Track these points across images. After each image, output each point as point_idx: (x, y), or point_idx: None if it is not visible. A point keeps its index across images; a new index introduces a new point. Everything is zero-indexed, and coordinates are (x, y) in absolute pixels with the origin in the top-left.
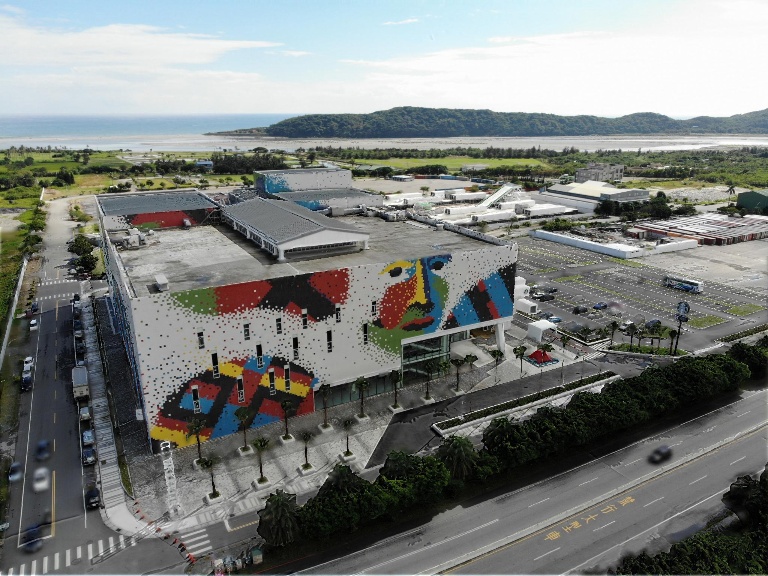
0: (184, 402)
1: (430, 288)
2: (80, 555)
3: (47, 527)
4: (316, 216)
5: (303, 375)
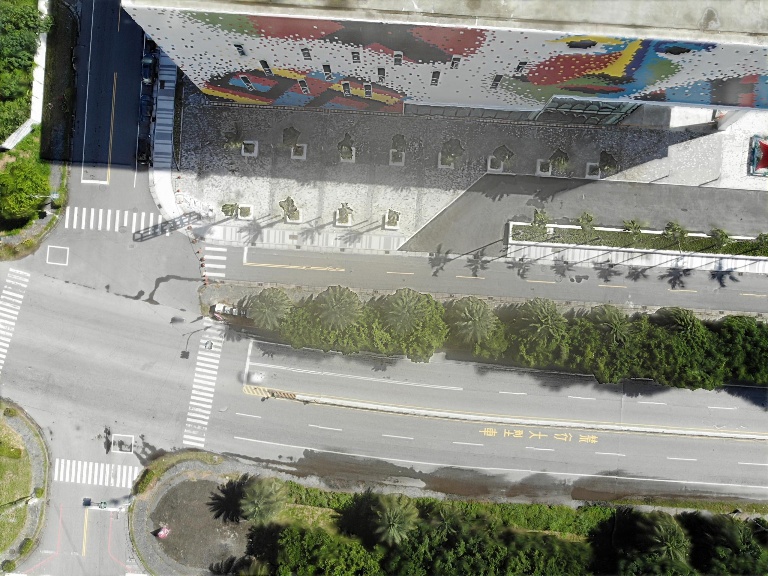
0: (233, 82)
1: (640, 66)
2: (126, 223)
3: (104, 168)
4: None
5: (391, 92)
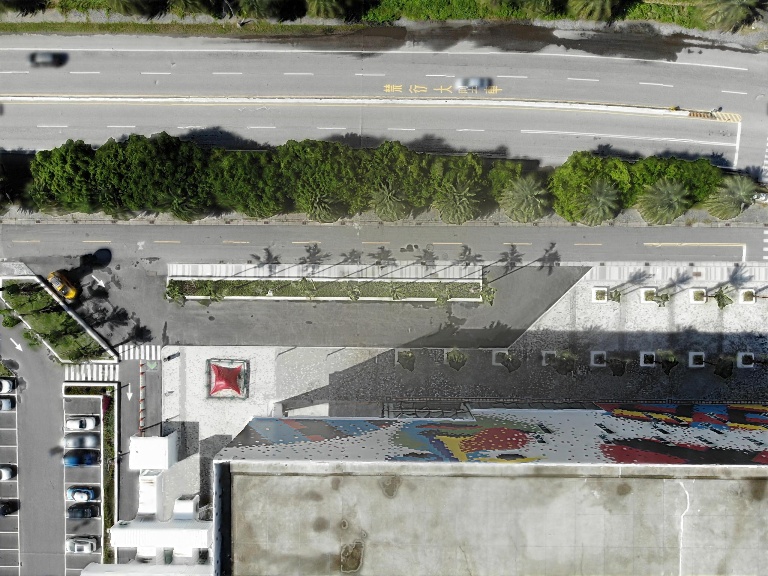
0: None
1: None
2: None
3: None
4: None
5: None
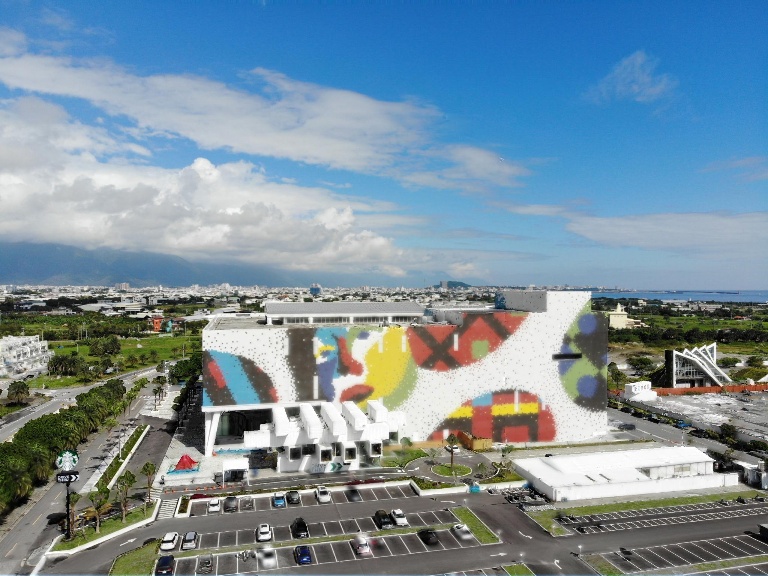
0: None
1: None
2: None
3: None
4: (328, 306)
5: None
